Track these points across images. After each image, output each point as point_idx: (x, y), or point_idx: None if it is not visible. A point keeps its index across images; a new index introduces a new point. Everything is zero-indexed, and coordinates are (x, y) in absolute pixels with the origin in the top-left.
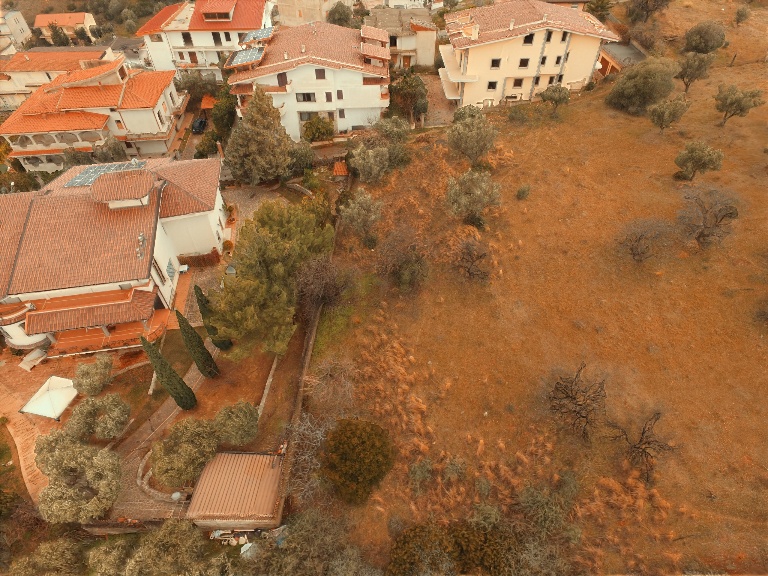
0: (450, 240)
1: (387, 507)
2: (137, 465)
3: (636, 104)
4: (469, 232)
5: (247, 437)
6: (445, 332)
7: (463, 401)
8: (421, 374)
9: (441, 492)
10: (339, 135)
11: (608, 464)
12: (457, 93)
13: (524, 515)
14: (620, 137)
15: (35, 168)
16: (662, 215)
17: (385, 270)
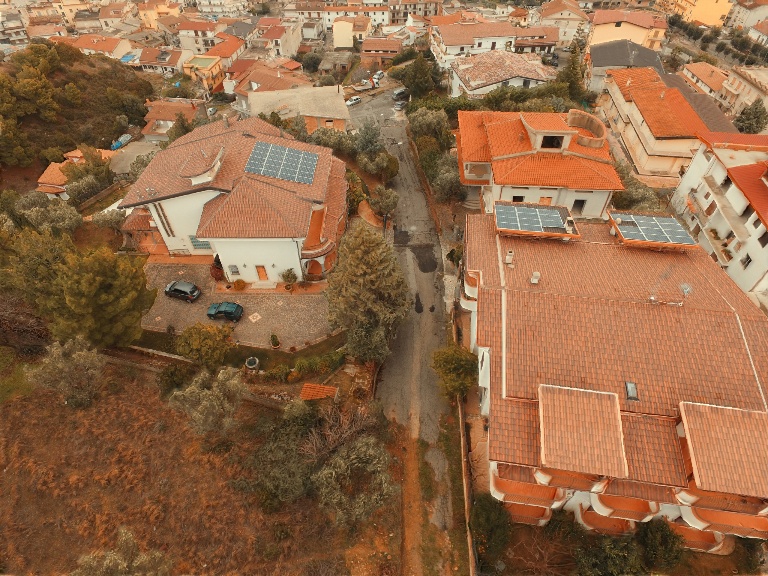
0: None
1: None
2: None
3: None
4: None
5: None
6: None
7: None
8: None
9: None
10: (480, 417)
11: None
12: None
13: None
14: None
15: None
16: None
17: None
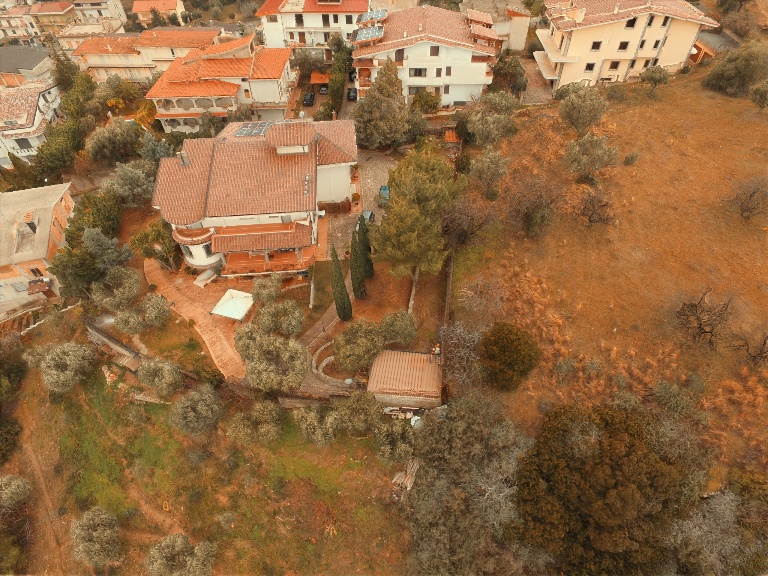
0: (566, 195)
1: (536, 393)
2: (309, 359)
3: (735, 85)
4: (583, 190)
5: (409, 337)
6: (570, 268)
7: (592, 321)
8: (552, 299)
9: (582, 384)
10: (442, 109)
11: (728, 372)
12: (554, 74)
13: (658, 403)
14: (719, 115)
15: (173, 130)
16: (766, 182)
17: (518, 213)
